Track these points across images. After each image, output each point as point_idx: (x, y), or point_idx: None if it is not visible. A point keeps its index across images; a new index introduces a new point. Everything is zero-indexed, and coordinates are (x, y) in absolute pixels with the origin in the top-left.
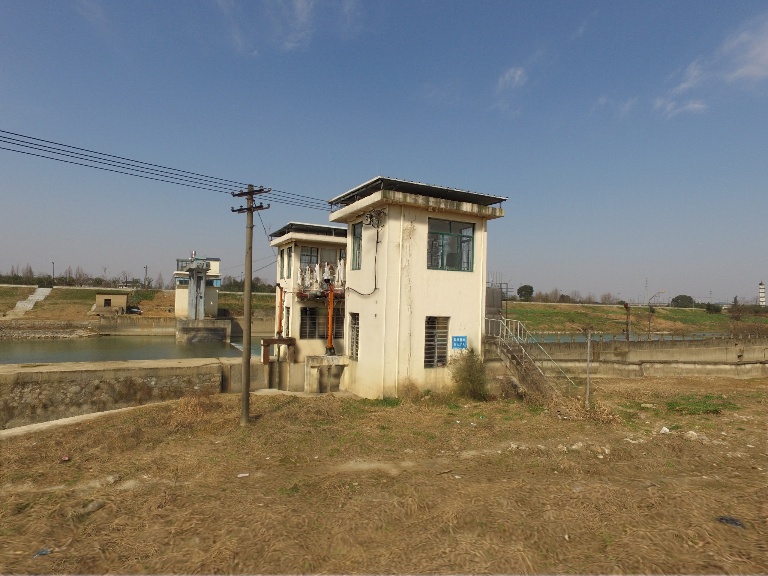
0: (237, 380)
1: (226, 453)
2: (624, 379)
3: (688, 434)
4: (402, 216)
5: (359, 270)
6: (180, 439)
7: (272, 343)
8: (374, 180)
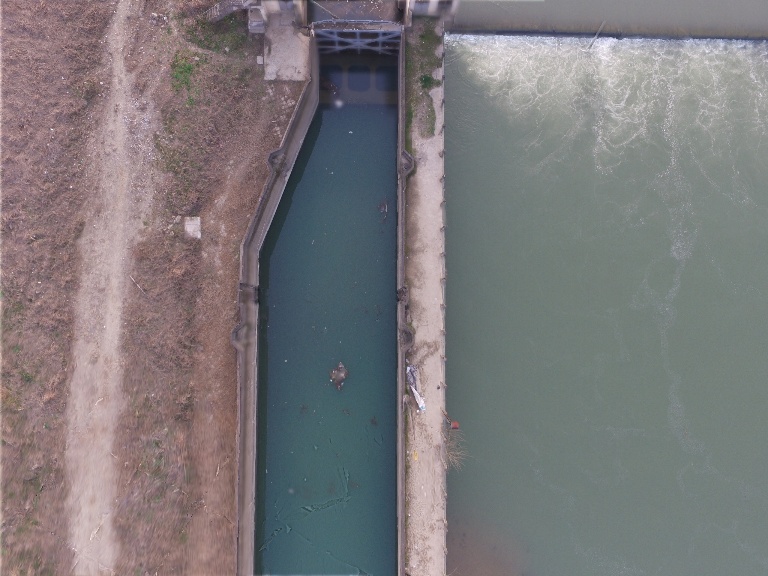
0: None
1: None
2: None
3: (154, 13)
4: None
5: None
6: None
7: None
8: None
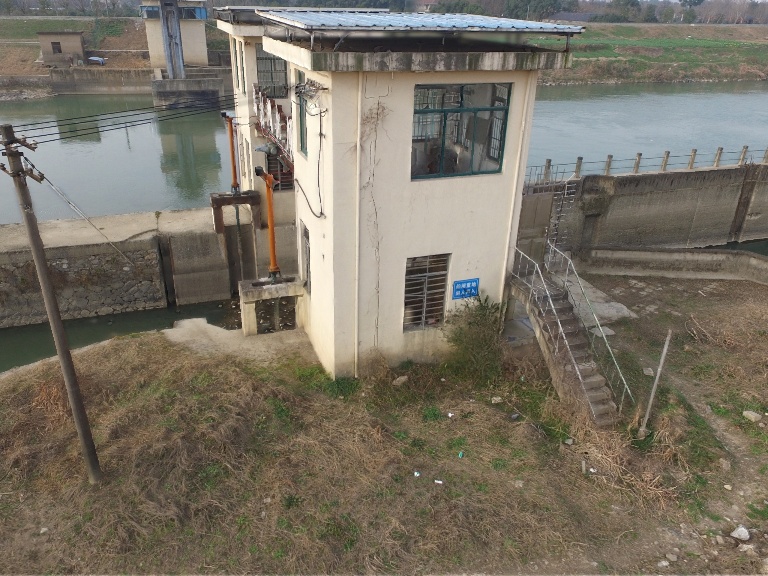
0: (182, 256)
1: (44, 567)
2: (760, 285)
3: None
4: (360, 93)
5: (306, 161)
6: (6, 503)
7: (225, 204)
8: (299, 26)
